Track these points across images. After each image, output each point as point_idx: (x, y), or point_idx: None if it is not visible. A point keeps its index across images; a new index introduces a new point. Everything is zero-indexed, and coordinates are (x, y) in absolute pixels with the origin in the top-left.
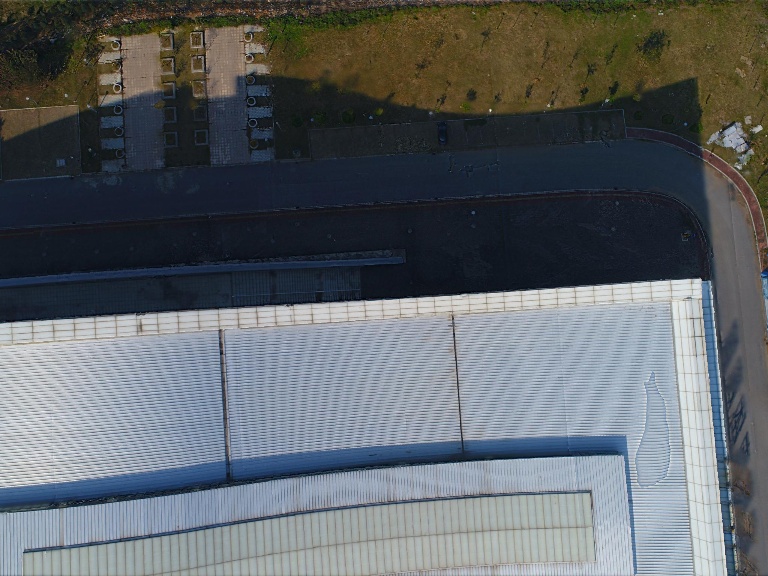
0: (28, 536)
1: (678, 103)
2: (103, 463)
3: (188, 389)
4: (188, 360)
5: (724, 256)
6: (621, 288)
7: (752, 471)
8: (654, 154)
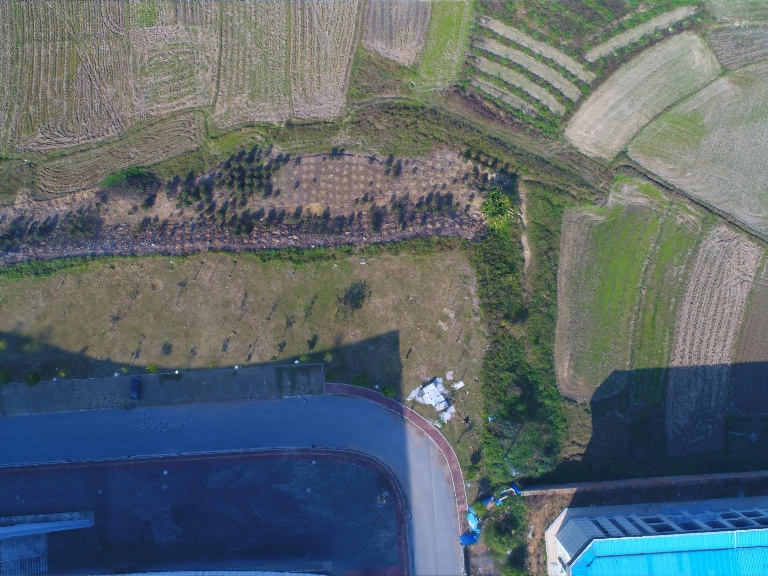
0: None
1: (378, 357)
2: None
3: None
4: None
5: (423, 518)
6: None
7: None
8: (353, 410)
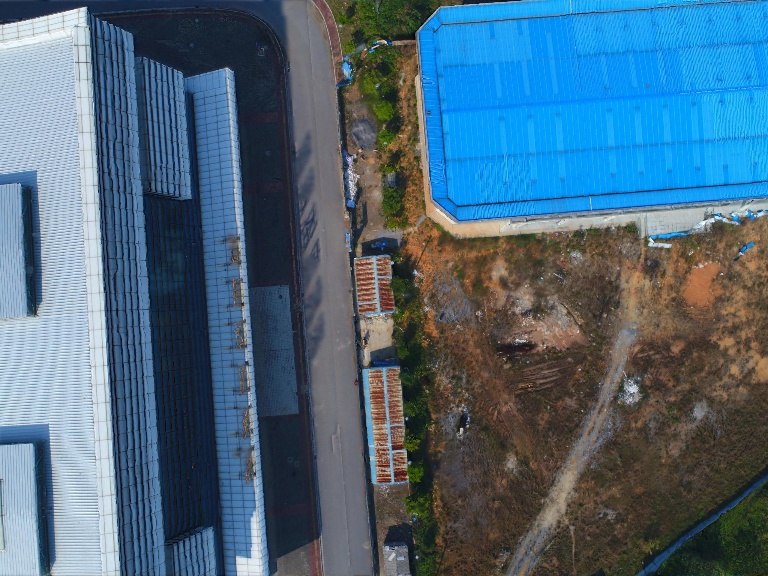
0: None
1: None
2: None
3: None
4: None
5: (300, 70)
6: (25, 24)
7: (322, 276)
8: None
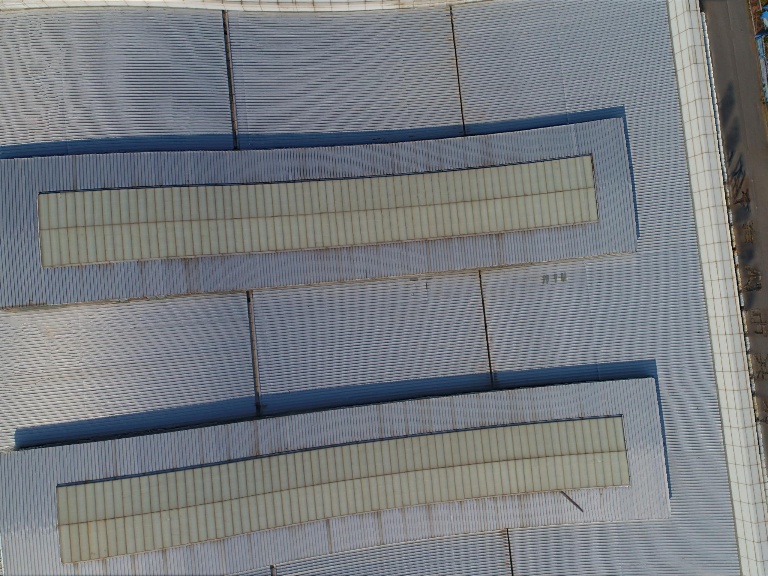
0: (42, 180)
1: None
2: (113, 124)
3: (194, 62)
4: (193, 35)
5: (718, 21)
6: None
7: (754, 227)
8: None
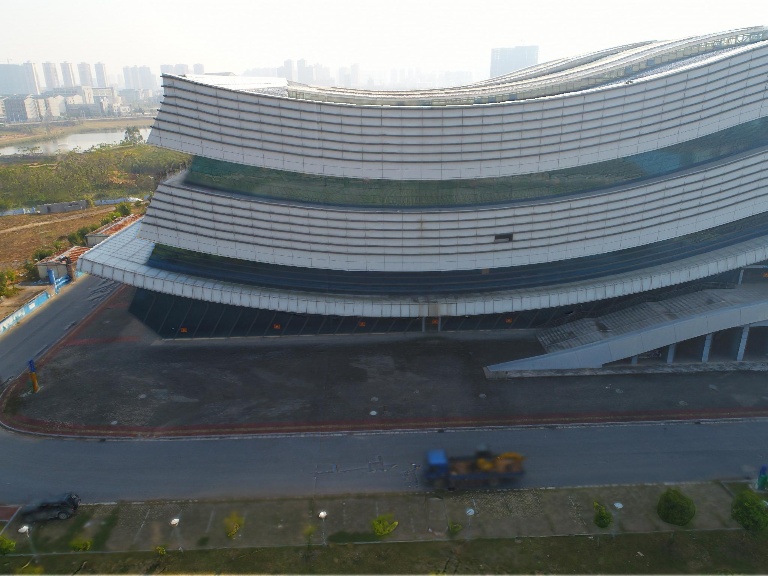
0: None
1: None
2: None
3: None
4: None
5: None
6: None
7: None
8: None
